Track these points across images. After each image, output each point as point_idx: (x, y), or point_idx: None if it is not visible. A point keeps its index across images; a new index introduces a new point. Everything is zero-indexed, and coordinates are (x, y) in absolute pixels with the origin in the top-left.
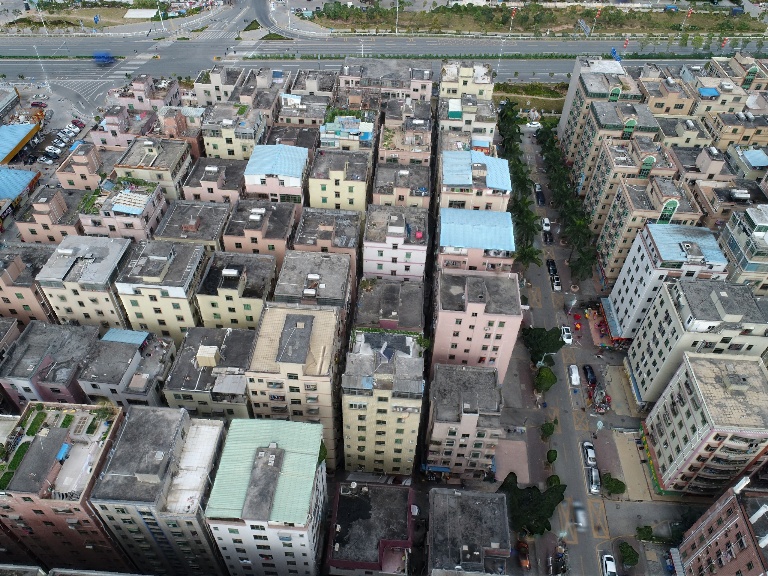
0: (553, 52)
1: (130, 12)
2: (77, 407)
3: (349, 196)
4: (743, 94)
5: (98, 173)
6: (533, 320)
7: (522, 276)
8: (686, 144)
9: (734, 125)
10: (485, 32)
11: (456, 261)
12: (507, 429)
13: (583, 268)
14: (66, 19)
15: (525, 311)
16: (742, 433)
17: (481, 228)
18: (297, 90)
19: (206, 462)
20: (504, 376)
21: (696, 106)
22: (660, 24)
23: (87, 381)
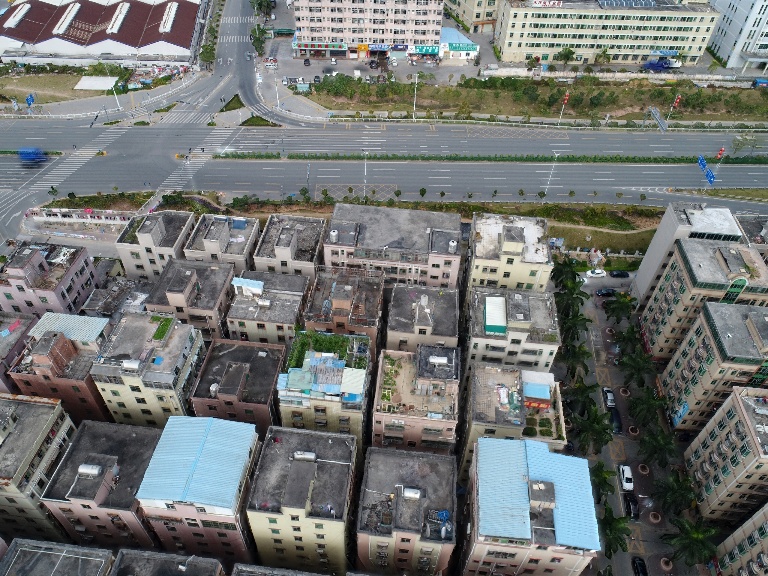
0: (617, 152)
1: (83, 81)
2: None
3: (316, 531)
4: None
5: None
6: None
7: None
8: None
9: None
10: (527, 119)
11: None
12: None
13: None
14: (1, 92)
15: None
16: None
17: None
18: (263, 258)
19: None
20: None
21: None
22: (751, 108)
23: None
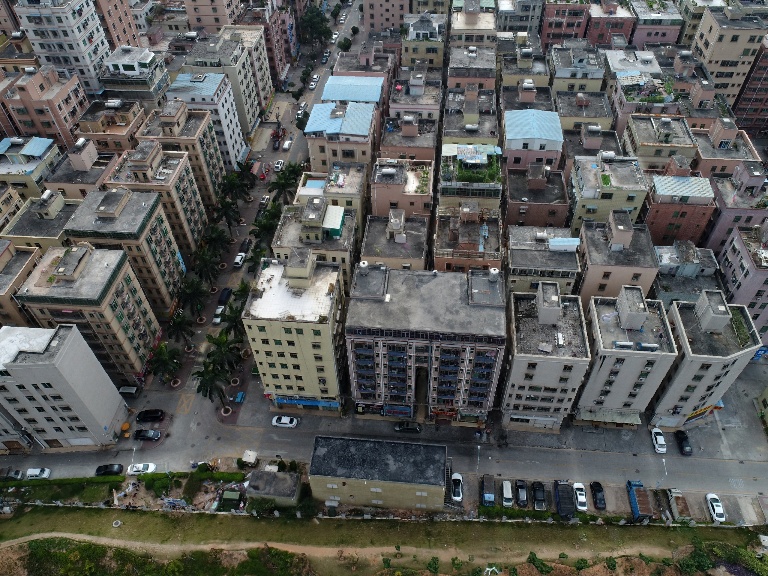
0: None
1: None
2: (568, 5)
3: None
4: None
5: (707, 137)
6: None
7: None
8: None
9: (0, 186)
10: None
11: None
12: None
13: None
14: None
15: None
16: None
17: (351, 83)
18: (569, 295)
19: (501, 5)
20: None
21: None
22: None
23: (582, 38)
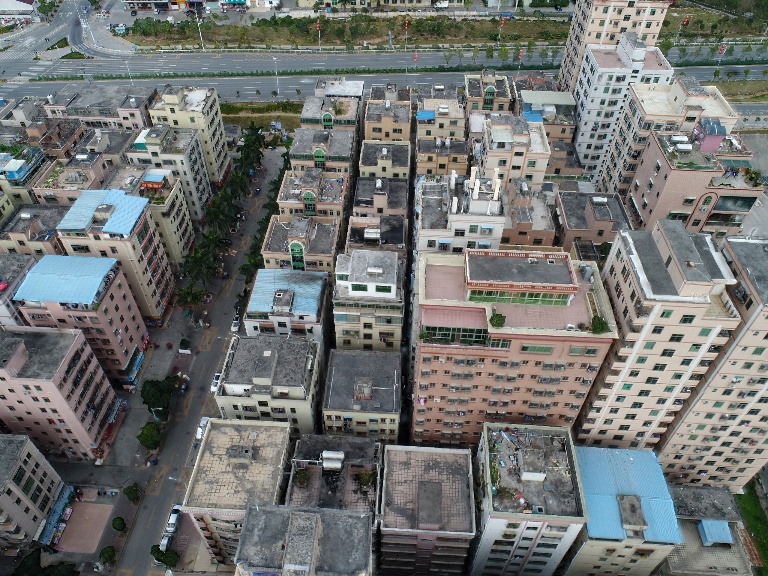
0: None
1: None
2: None
3: None
4: (460, 117)
5: None
6: (192, 365)
7: (191, 318)
8: (384, 173)
9: (427, 153)
10: (295, 46)
11: (40, 314)
12: (101, 491)
13: (242, 310)
14: None
15: (188, 355)
16: (215, 514)
17: (67, 279)
18: (6, 120)
19: None
20: (88, 436)
21: (417, 130)
22: (486, 33)
23: None
